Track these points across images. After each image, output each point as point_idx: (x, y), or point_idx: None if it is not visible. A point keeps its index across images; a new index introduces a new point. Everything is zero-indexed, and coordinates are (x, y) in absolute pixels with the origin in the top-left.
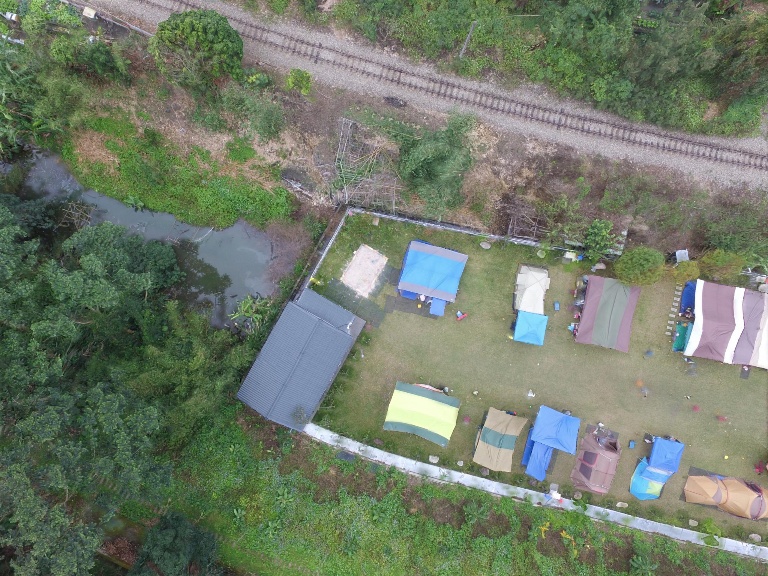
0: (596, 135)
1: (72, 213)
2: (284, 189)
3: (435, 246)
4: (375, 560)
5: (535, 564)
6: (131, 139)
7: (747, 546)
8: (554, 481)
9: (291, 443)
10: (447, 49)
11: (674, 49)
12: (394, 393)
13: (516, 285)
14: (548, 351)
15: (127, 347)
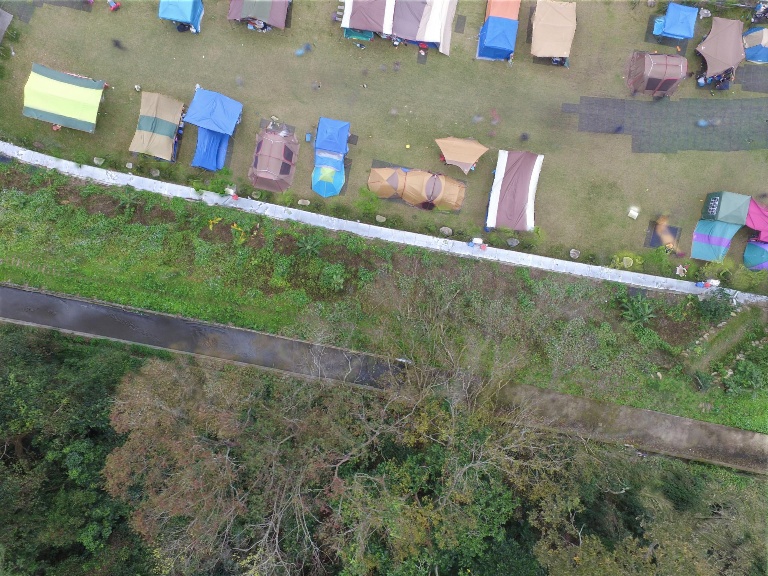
0: None
1: None
2: None
3: None
4: (3, 235)
5: (191, 246)
6: None
7: (438, 240)
8: (231, 181)
9: None
10: None
11: None
12: (31, 75)
13: None
14: (213, 42)
15: None
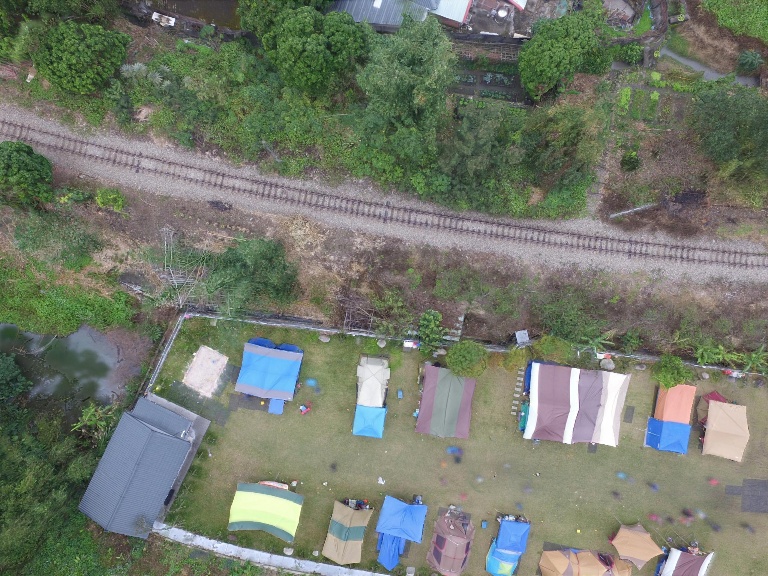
0: (423, 226)
1: None
2: (124, 293)
3: (267, 348)
4: None
5: None
6: None
7: None
8: (410, 564)
9: (142, 547)
10: (267, 151)
11: (480, 146)
12: (236, 495)
13: (357, 376)
14: (395, 438)
15: None
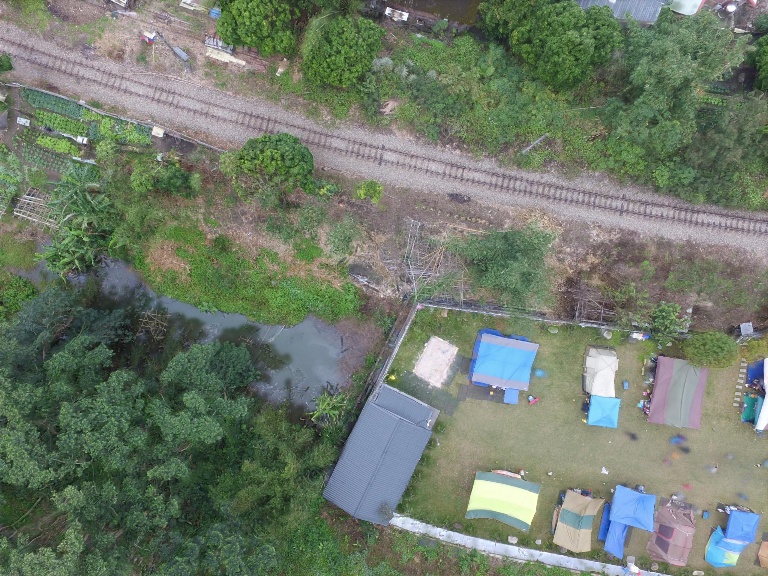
0: (658, 218)
1: (148, 322)
2: (351, 284)
3: (507, 338)
4: None
5: None
6: (201, 246)
7: None
8: (630, 554)
9: (375, 534)
10: (508, 144)
11: (738, 139)
12: (474, 483)
13: (585, 367)
14: (619, 429)
15: (211, 451)
